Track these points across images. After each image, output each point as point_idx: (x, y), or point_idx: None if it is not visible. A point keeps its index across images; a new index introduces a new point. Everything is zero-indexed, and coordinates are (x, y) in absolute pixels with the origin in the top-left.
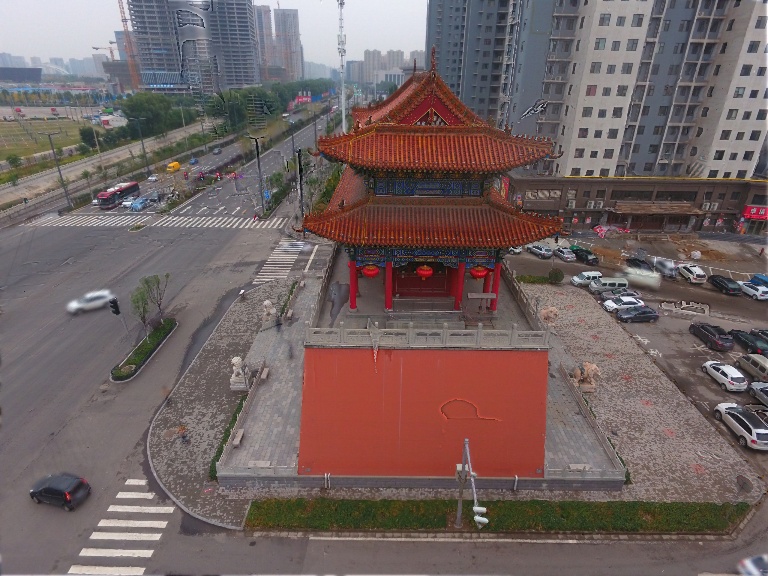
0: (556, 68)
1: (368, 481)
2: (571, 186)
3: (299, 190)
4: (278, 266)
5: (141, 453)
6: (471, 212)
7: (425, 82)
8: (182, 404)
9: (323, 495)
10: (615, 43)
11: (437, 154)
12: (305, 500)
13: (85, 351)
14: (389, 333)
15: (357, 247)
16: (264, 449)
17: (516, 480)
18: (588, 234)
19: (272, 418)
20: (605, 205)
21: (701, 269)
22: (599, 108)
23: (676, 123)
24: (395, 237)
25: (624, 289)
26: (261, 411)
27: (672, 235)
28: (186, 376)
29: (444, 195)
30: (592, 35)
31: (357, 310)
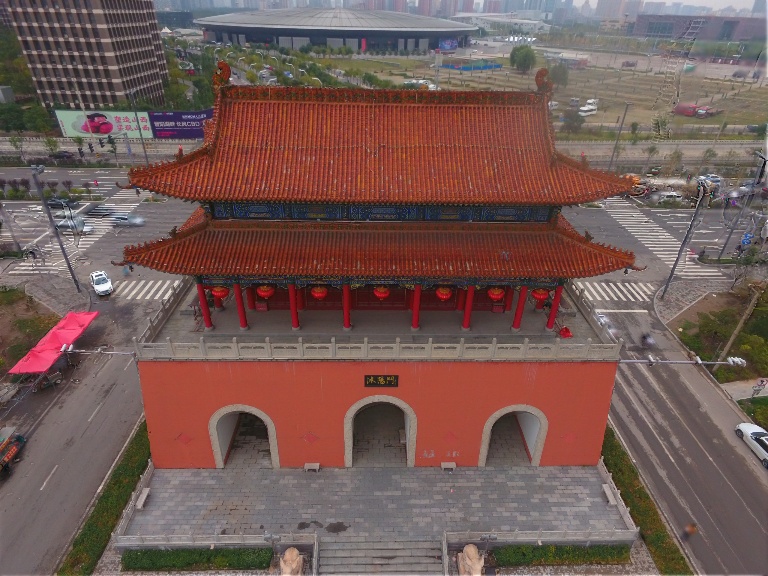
0: None
1: None
2: None
3: None
4: None
5: None
6: None
7: None
8: None
9: None
10: None
11: None
12: None
13: None
14: None
15: None
16: None
17: None
18: None
19: None
20: None
21: None
22: None
23: None
24: None
25: None
26: None
27: None
28: None
29: None
30: None
31: None
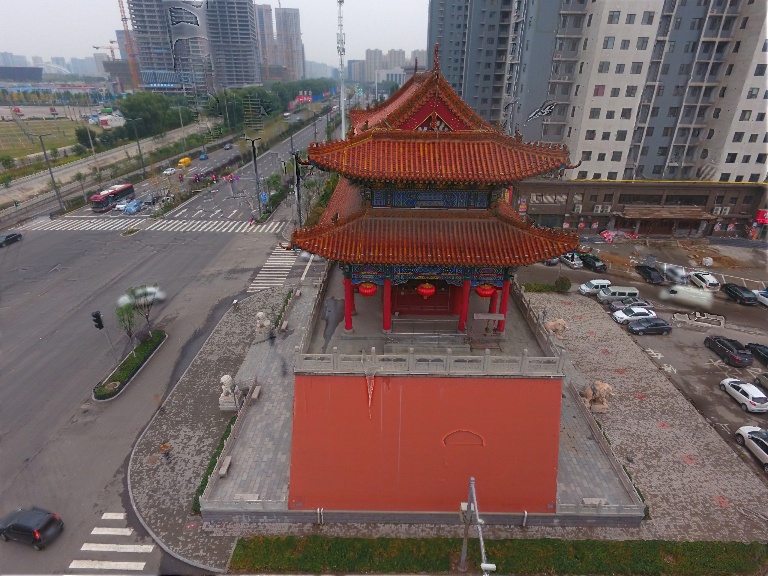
0: (562, 68)
1: (364, 516)
2: (578, 190)
3: (296, 194)
4: (274, 273)
5: (121, 482)
6: (477, 226)
7: (427, 83)
8: (167, 426)
9: (315, 532)
10: (624, 42)
11: (440, 163)
12: (296, 538)
13: (68, 366)
14: (387, 358)
15: (352, 264)
16: (253, 479)
17: (525, 516)
18: (595, 239)
19: (262, 443)
20: (613, 209)
21: (714, 277)
22: (607, 109)
23: (686, 124)
24: (394, 254)
25: (634, 299)
26: (251, 435)
27: (682, 240)
28: (173, 394)
29: (448, 207)
30: (600, 33)
31: (353, 331)
